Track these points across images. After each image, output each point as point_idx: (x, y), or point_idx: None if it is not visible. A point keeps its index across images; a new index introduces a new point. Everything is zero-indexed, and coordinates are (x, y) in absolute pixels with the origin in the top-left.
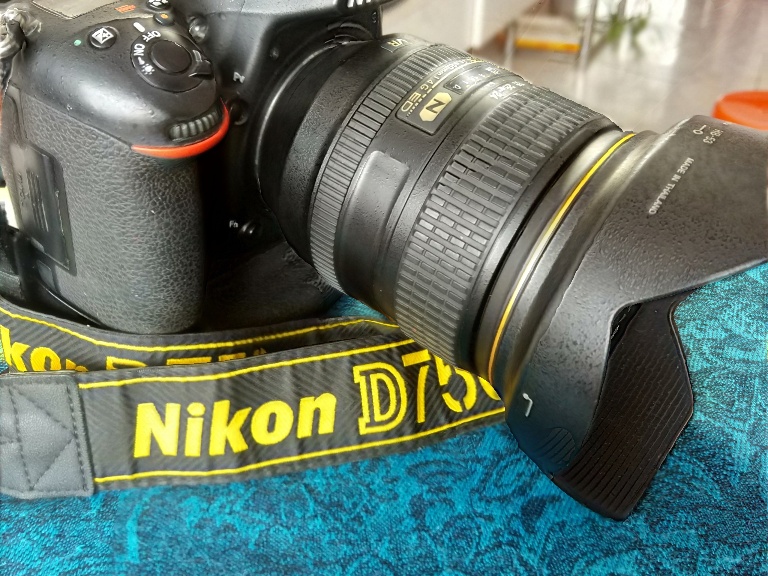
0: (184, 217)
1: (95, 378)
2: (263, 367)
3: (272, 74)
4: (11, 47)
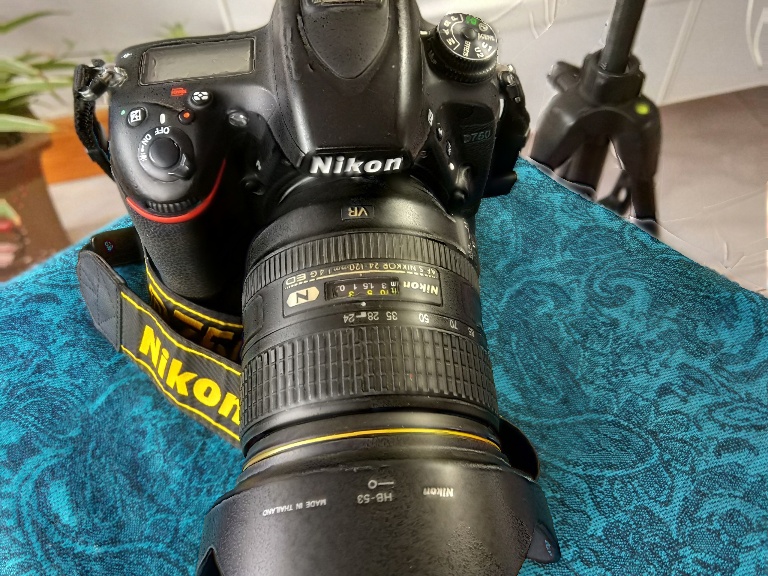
0: (174, 246)
1: (129, 295)
2: (210, 358)
3: (286, 173)
4: (91, 96)
